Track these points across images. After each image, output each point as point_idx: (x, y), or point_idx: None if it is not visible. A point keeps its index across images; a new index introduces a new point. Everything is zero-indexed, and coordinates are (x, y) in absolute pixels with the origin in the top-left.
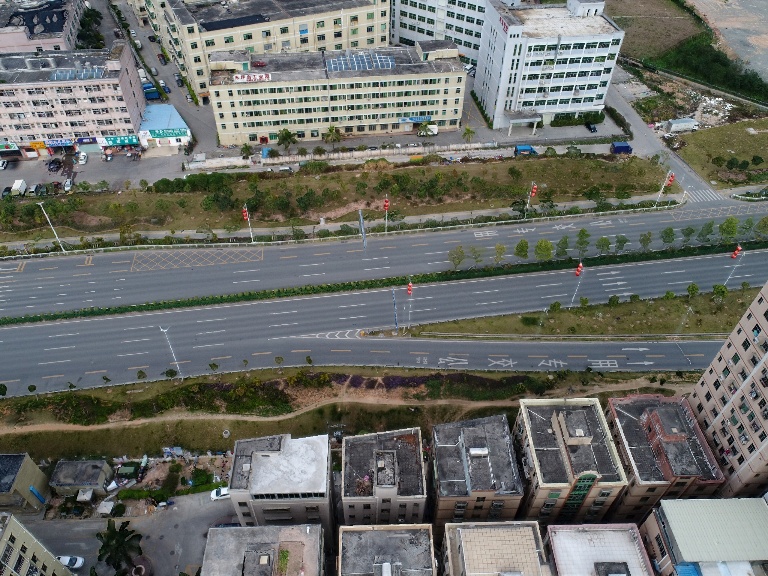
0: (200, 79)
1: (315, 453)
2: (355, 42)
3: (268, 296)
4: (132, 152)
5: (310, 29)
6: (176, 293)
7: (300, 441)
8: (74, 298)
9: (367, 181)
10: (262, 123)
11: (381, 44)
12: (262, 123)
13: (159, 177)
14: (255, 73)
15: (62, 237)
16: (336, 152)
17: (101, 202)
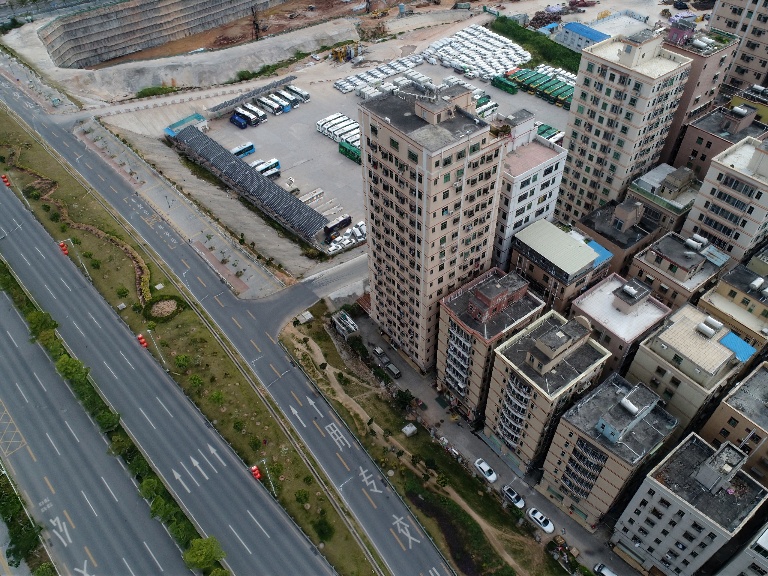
0: None
1: None
2: None
3: None
4: None
5: None
6: None
7: None
8: None
9: None
10: None
11: None
12: None
13: None
14: None
15: None
16: None
17: None
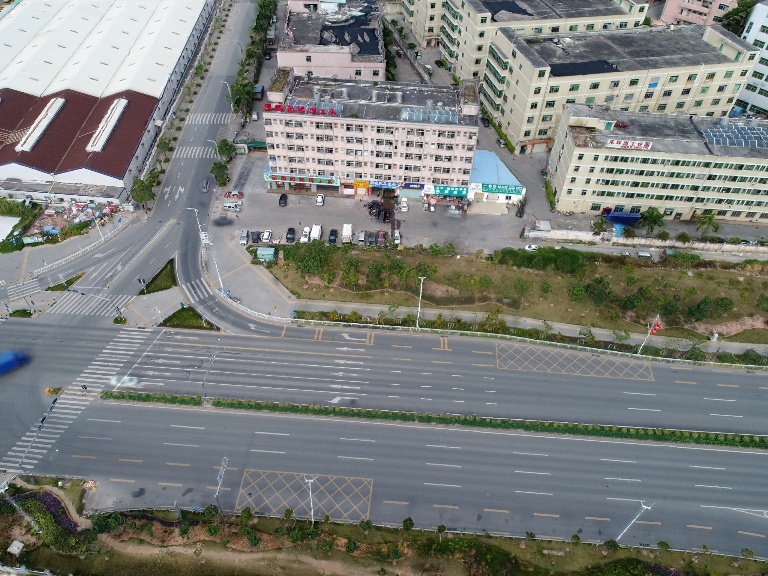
0: (527, 126)
1: None
2: (699, 101)
3: (684, 439)
4: (455, 204)
5: (660, 83)
6: (562, 411)
7: None
8: (442, 394)
9: (756, 289)
10: (614, 193)
11: (725, 106)
12: (614, 193)
13: (494, 241)
14: (621, 136)
15: (407, 306)
16: (703, 242)
17: (453, 272)
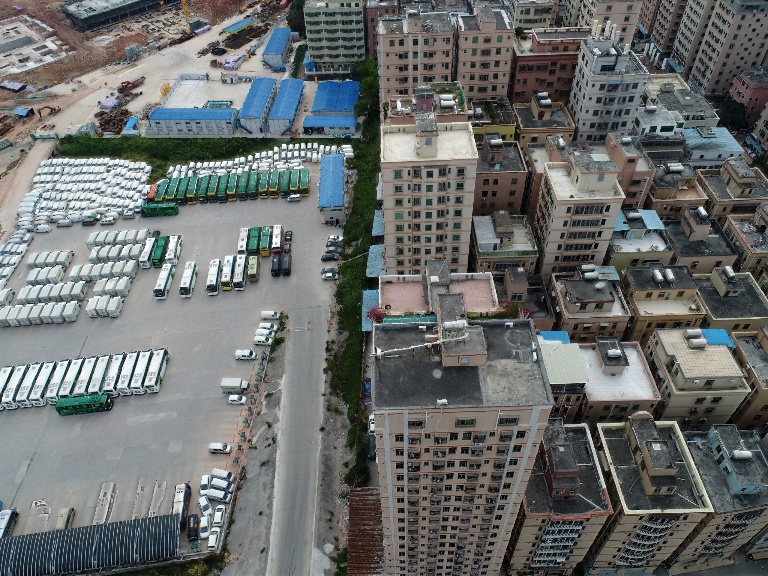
0: None
1: None
2: None
3: None
4: None
5: None
6: None
7: None
8: None
9: None
10: None
11: None
12: None
13: None
14: None
15: None
16: None
17: None
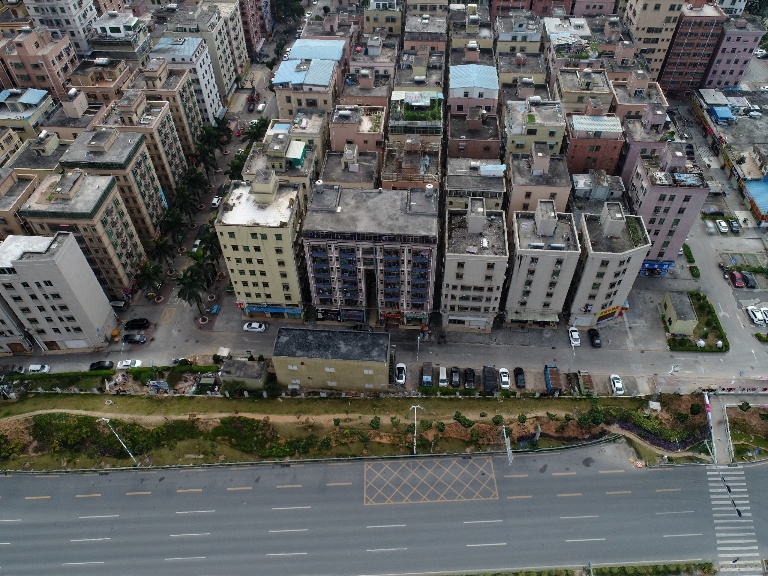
0: None
1: (1, 256)
2: None
3: None
4: None
5: None
6: None
7: (8, 264)
8: None
9: None
10: None
11: None
12: None
13: None
14: None
15: None
16: None
17: None
